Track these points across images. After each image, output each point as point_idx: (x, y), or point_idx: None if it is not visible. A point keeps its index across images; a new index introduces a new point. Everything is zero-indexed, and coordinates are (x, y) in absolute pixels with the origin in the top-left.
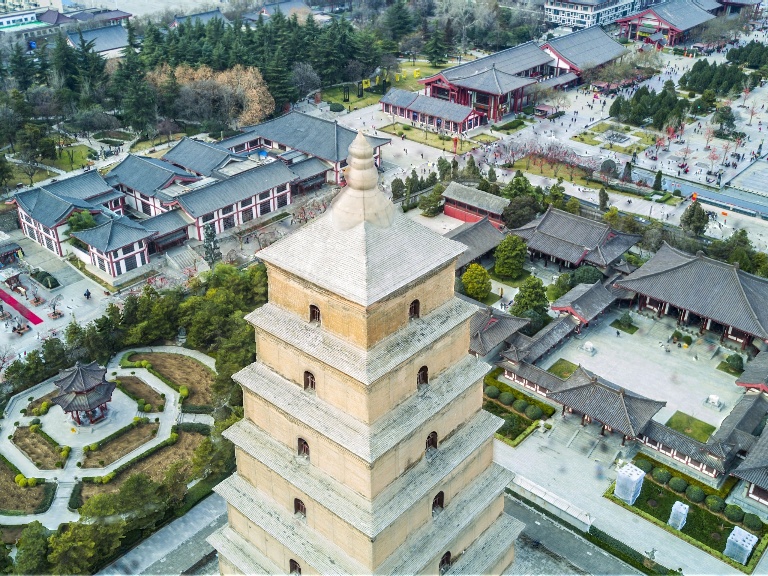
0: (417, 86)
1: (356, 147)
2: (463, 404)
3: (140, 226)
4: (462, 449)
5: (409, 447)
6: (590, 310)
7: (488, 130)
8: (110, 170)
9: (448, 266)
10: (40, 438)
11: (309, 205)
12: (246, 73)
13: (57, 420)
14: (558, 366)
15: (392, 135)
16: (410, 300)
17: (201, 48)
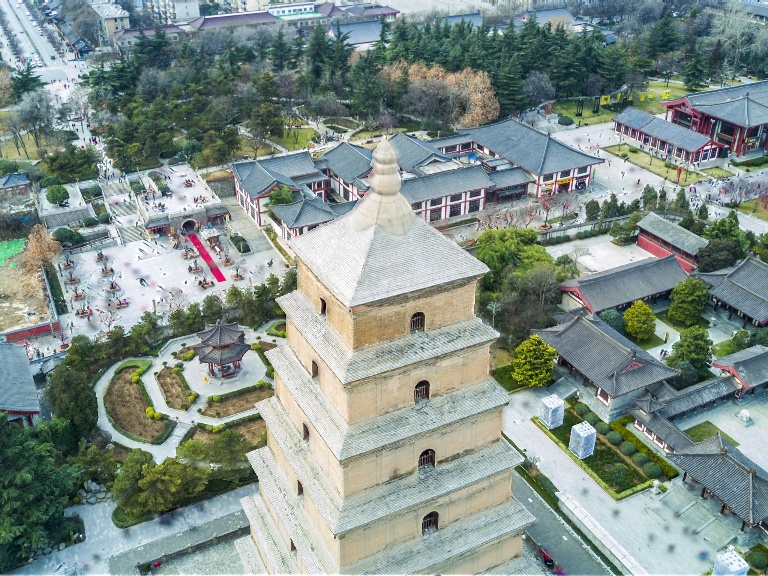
0: (662, 108)
1: (377, 152)
2: (472, 430)
3: (329, 209)
4: (463, 475)
5: (396, 457)
6: (757, 376)
7: (725, 164)
8: (323, 154)
9: (465, 285)
10: (178, 380)
11: (501, 214)
12: (475, 77)
13: (197, 368)
14: (701, 428)
15: (614, 156)
16: (412, 311)
17: (440, 48)
